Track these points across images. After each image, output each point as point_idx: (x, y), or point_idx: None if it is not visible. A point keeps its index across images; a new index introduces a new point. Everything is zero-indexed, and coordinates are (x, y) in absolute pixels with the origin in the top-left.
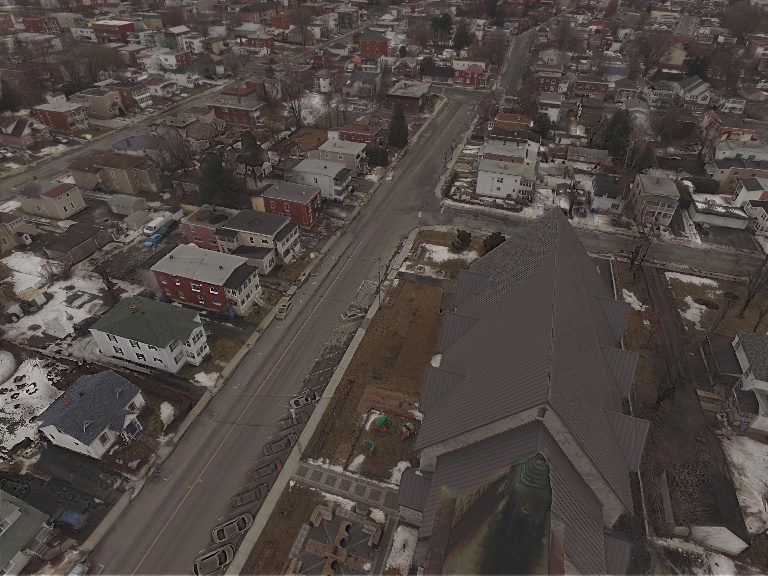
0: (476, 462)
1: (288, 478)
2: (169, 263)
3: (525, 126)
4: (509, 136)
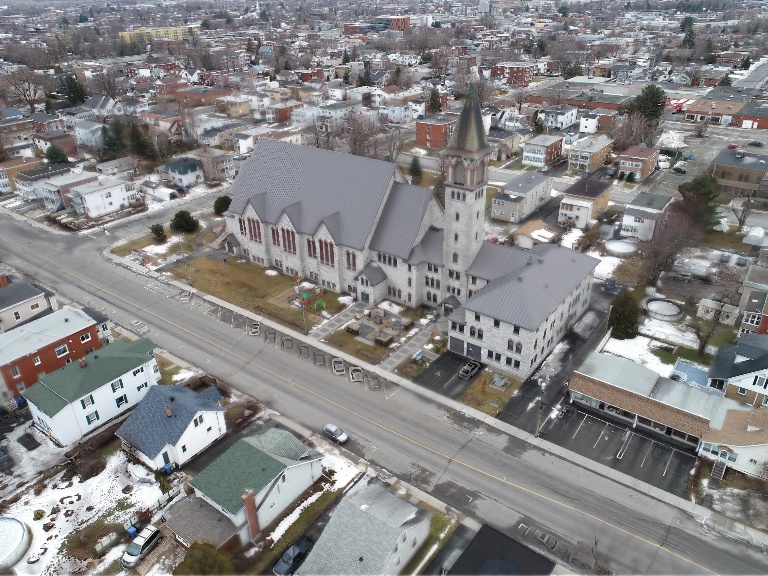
0: (391, 219)
1: (317, 341)
2: (5, 353)
3: (39, 164)
4: (50, 171)
